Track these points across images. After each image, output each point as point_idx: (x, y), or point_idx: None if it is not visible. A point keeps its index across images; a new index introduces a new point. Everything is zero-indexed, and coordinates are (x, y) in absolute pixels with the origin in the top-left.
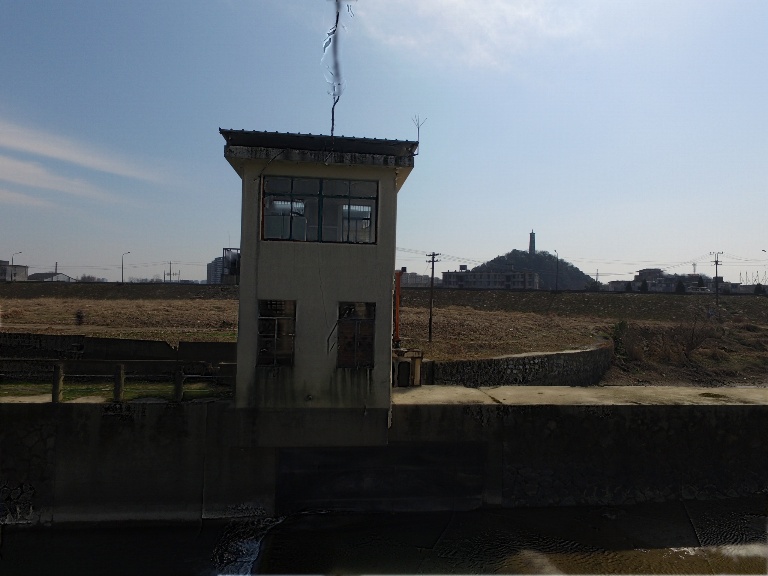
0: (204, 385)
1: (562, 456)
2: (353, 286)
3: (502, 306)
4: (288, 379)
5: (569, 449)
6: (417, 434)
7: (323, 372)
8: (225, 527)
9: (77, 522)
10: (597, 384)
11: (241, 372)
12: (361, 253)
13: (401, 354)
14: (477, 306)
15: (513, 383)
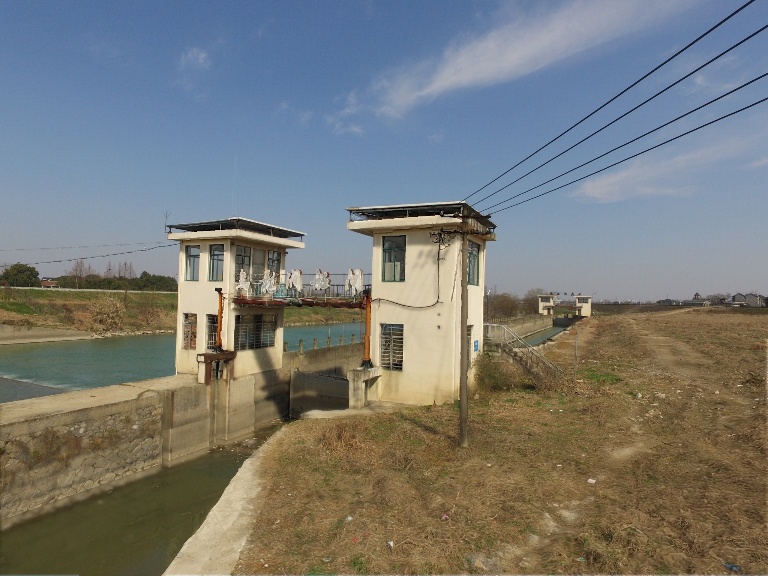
0: None
1: None
2: None
3: None
4: None
5: None
6: None
7: None
8: None
9: None
10: None
11: None
12: None
13: None
14: None
15: None
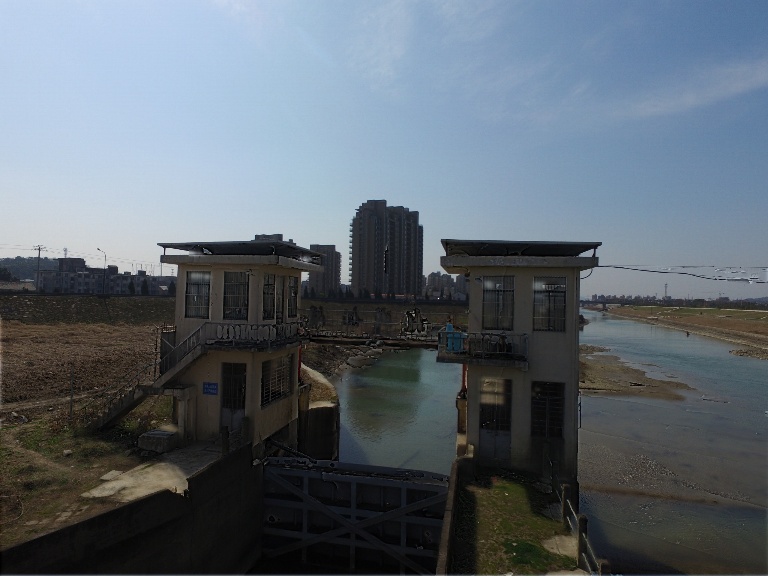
0: (476, 487)
1: None
2: None
3: (51, 316)
4: None
5: None
6: None
7: None
8: None
9: None
10: None
11: None
12: None
13: None
14: (14, 318)
15: None
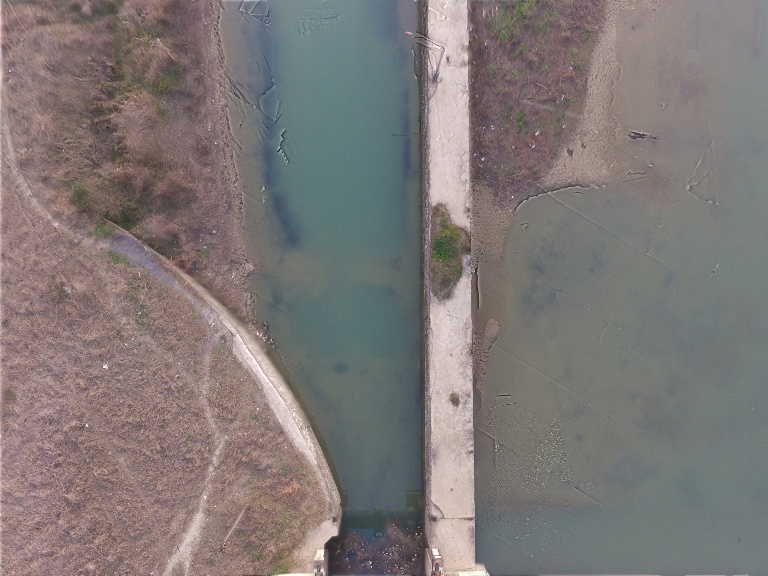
0: None
1: None
2: None
3: None
4: None
5: None
6: None
7: None
8: None
9: None
10: (245, 323)
11: None
12: None
13: None
14: None
15: None
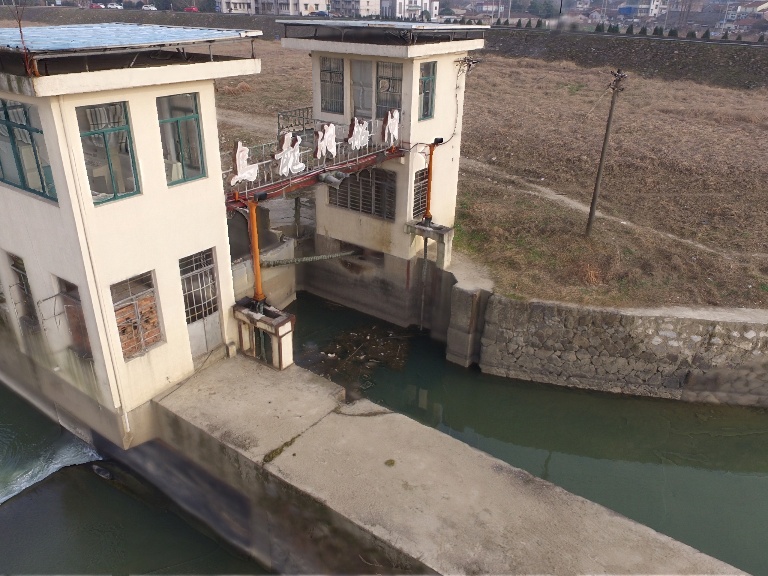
0: None
1: (337, 574)
2: (55, 258)
3: None
4: (41, 341)
5: (346, 572)
6: (182, 447)
7: (61, 347)
8: (73, 440)
9: (6, 384)
10: None
11: (13, 319)
12: (51, 216)
13: (253, 321)
14: None
15: (664, 362)
